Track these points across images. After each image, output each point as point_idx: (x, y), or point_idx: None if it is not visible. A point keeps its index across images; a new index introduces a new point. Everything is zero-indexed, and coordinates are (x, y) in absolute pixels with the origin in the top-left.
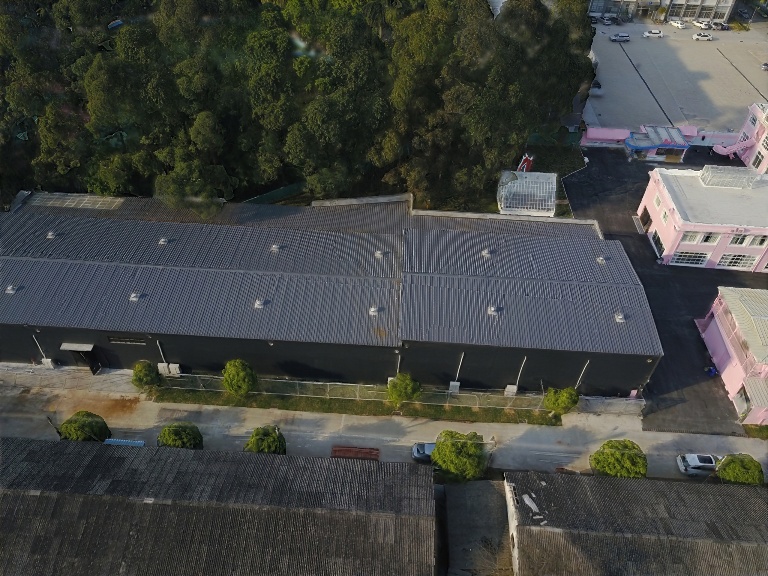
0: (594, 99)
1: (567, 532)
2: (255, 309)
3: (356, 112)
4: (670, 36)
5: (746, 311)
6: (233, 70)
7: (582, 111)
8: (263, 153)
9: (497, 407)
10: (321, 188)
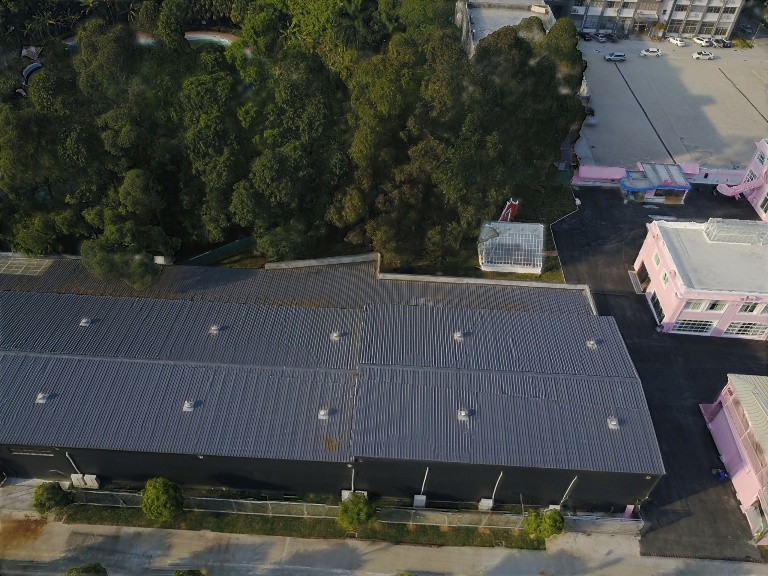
0: (587, 128)
1: None
2: (183, 413)
3: (311, 167)
4: (669, 54)
5: (761, 409)
6: (169, 120)
7: (573, 146)
8: (207, 211)
9: (469, 526)
10: (273, 252)
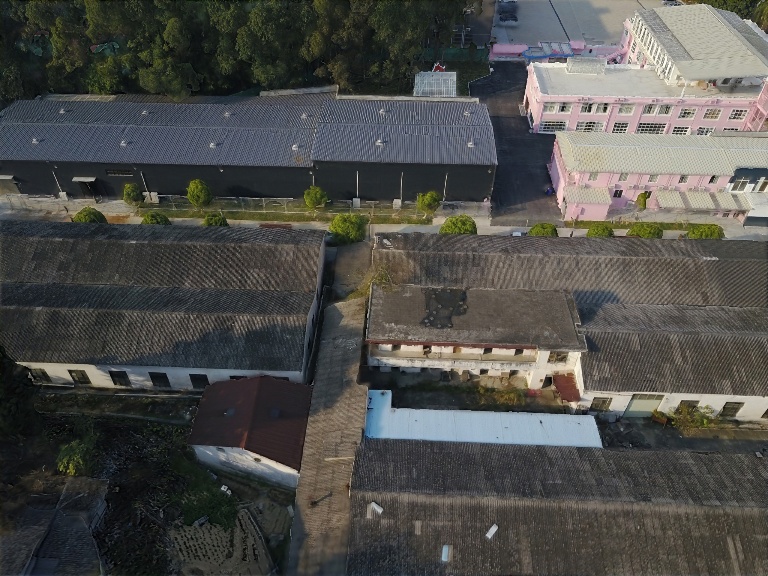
0: (510, 29)
1: (406, 252)
2: (210, 148)
3: (288, 16)
4: None
5: (568, 142)
6: None
7: (490, 32)
8: (221, 54)
9: (387, 215)
10: (265, 78)
